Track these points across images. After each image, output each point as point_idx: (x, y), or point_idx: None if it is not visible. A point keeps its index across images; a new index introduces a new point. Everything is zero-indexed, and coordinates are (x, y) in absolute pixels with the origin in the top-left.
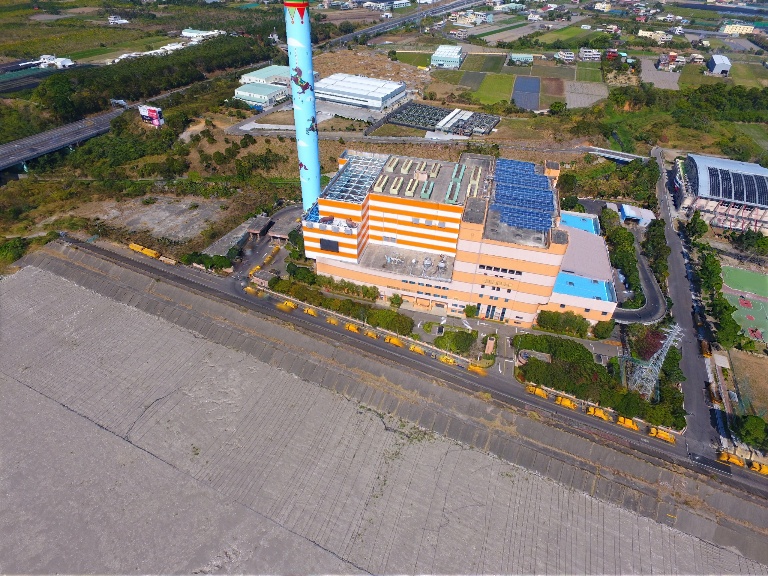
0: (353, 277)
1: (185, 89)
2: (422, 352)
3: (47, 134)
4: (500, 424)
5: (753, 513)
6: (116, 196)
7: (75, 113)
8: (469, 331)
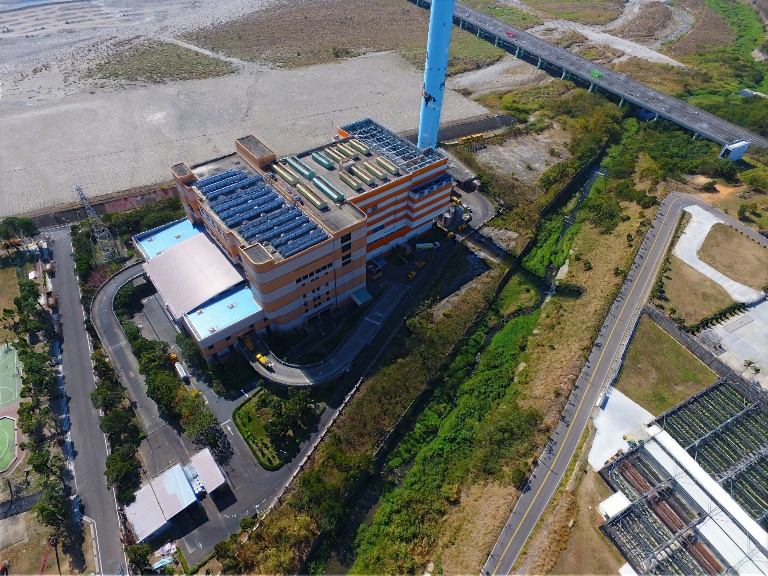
0: None
1: None
2: None
3: (727, 125)
4: None
5: None
6: None
7: None
8: None
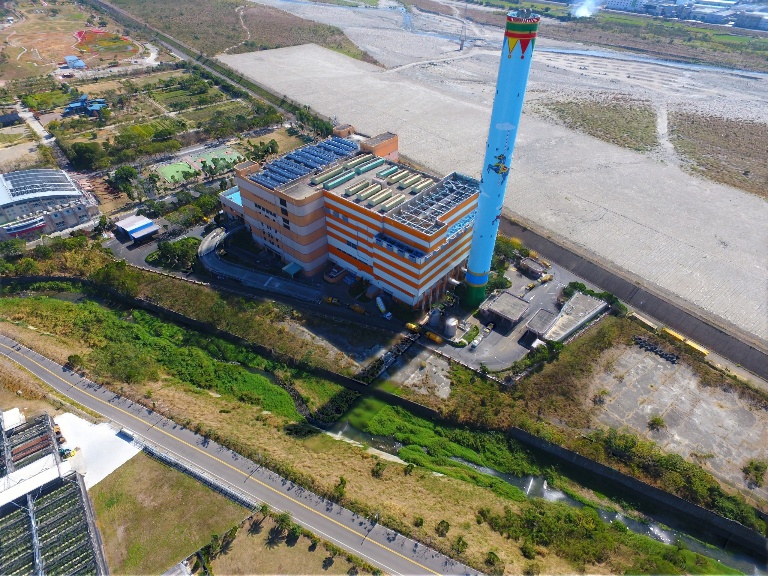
0: None
1: None
2: None
3: None
4: None
5: None
6: None
7: None
8: None
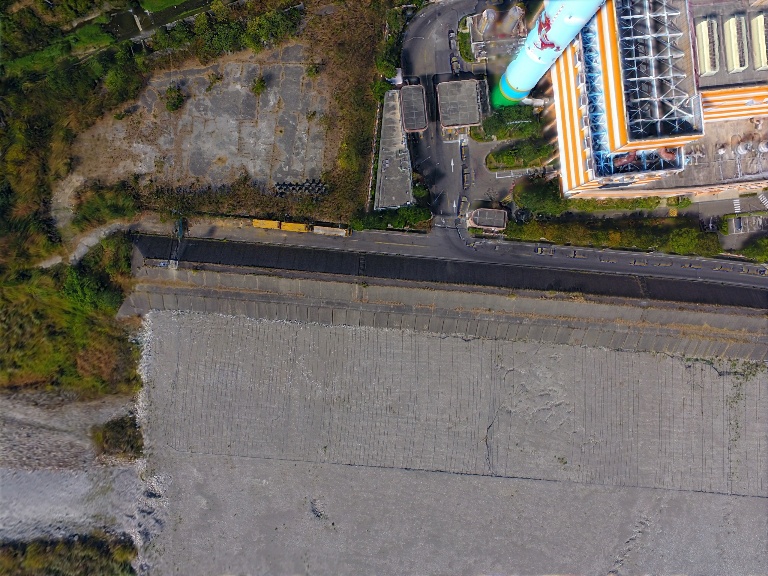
0: (629, 195)
1: None
2: (730, 270)
3: None
4: None
5: None
6: (106, 108)
7: None
8: None
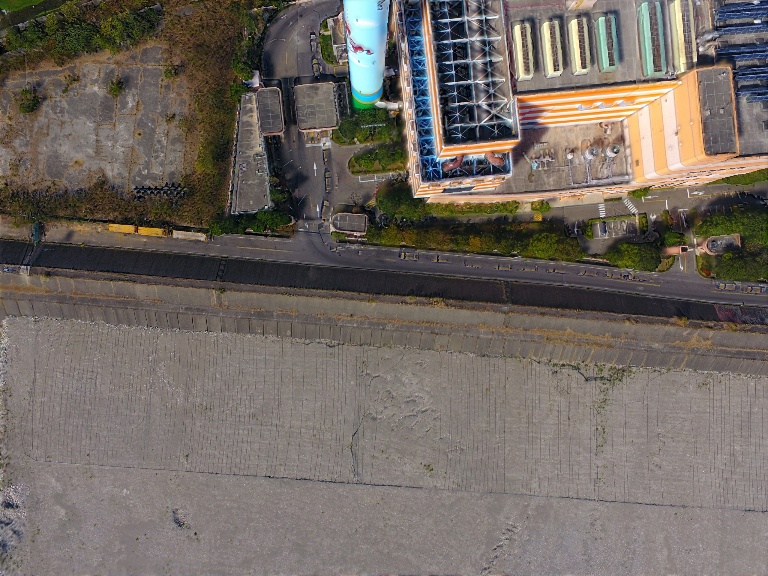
0: (484, 200)
1: None
2: (594, 275)
3: None
4: (696, 342)
5: None
6: None
7: None
8: (636, 218)
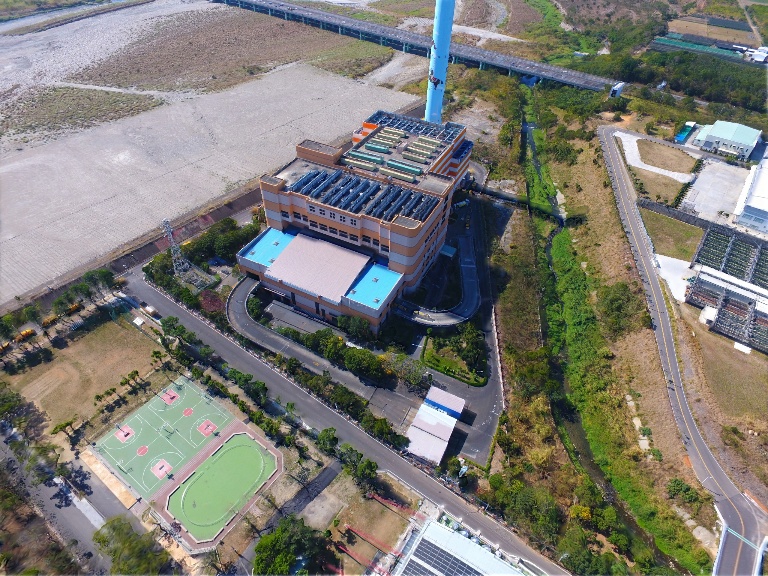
0: None
1: (712, 103)
2: None
3: (590, 76)
4: None
5: (84, 270)
6: None
7: (628, 75)
8: None
